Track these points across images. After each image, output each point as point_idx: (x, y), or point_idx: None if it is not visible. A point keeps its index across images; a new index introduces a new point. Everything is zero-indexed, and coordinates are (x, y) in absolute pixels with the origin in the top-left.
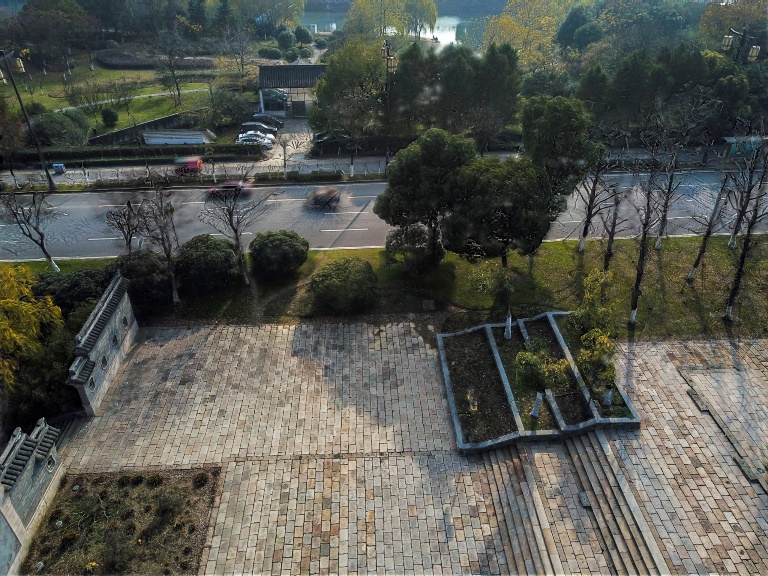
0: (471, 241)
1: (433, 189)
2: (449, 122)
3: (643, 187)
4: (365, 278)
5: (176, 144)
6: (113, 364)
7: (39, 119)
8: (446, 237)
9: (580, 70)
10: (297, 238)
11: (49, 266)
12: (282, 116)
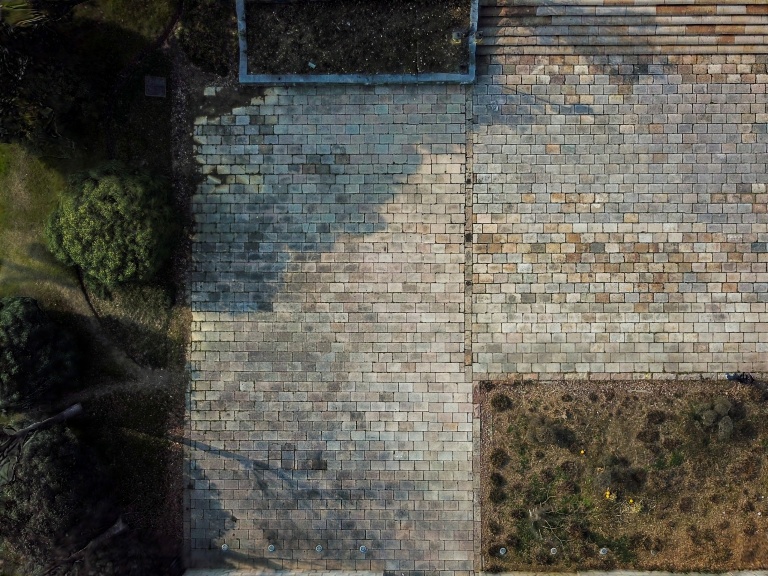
0: None
1: None
2: None
3: None
4: None
5: None
6: None
7: None
8: None
9: None
10: None
11: None
12: None
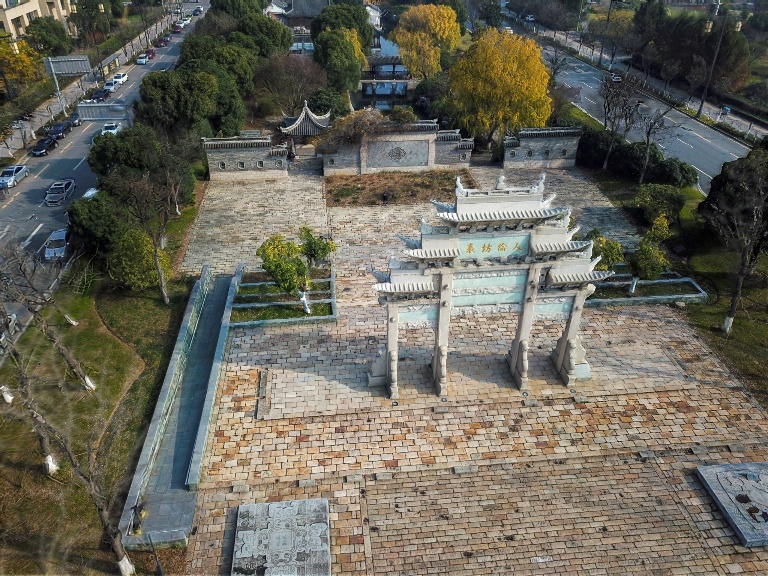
0: None
1: None
2: None
3: (760, 185)
4: None
5: None
6: (536, 161)
7: (766, 80)
8: None
9: None
10: (689, 173)
11: None
12: None
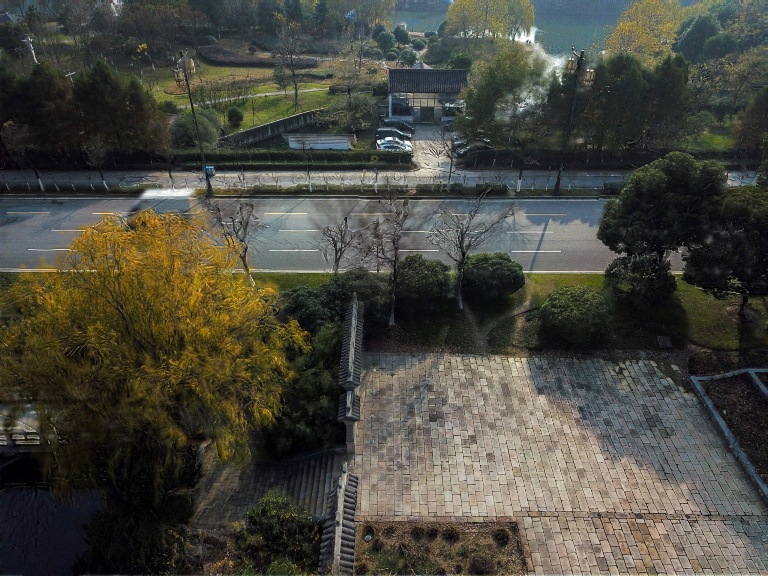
0: (731, 277)
1: (683, 218)
2: (607, 136)
3: None
4: (606, 311)
5: (323, 149)
6: None
7: (181, 118)
8: (694, 270)
9: (728, 84)
10: (512, 262)
11: (246, 279)
12: (409, 121)
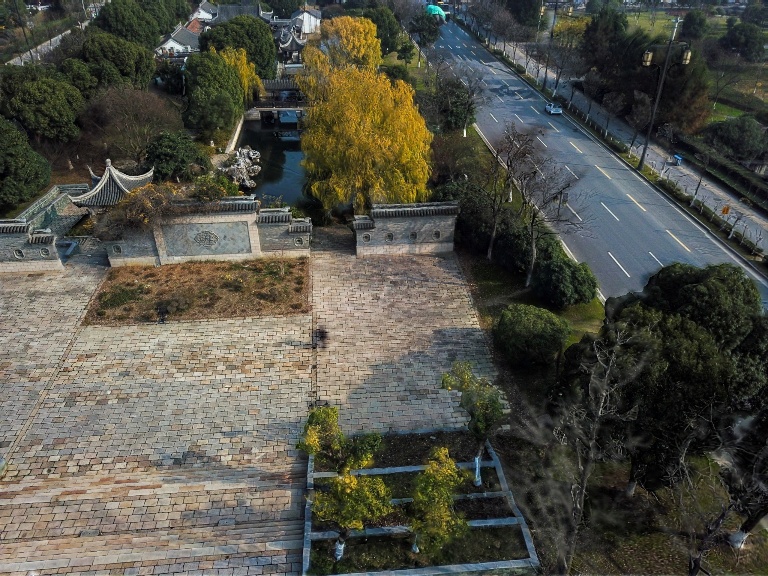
0: None
1: None
2: None
3: (579, 452)
4: (525, 337)
5: None
6: (400, 246)
7: None
8: None
9: None
10: (584, 284)
11: None
12: None
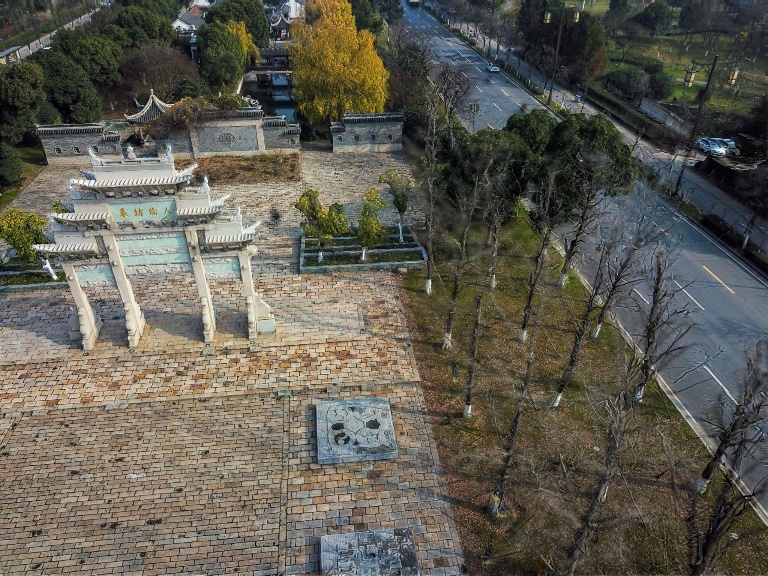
0: None
1: None
2: None
3: None
4: None
5: (645, 115)
6: (364, 146)
7: None
8: None
9: None
10: None
11: None
12: None
